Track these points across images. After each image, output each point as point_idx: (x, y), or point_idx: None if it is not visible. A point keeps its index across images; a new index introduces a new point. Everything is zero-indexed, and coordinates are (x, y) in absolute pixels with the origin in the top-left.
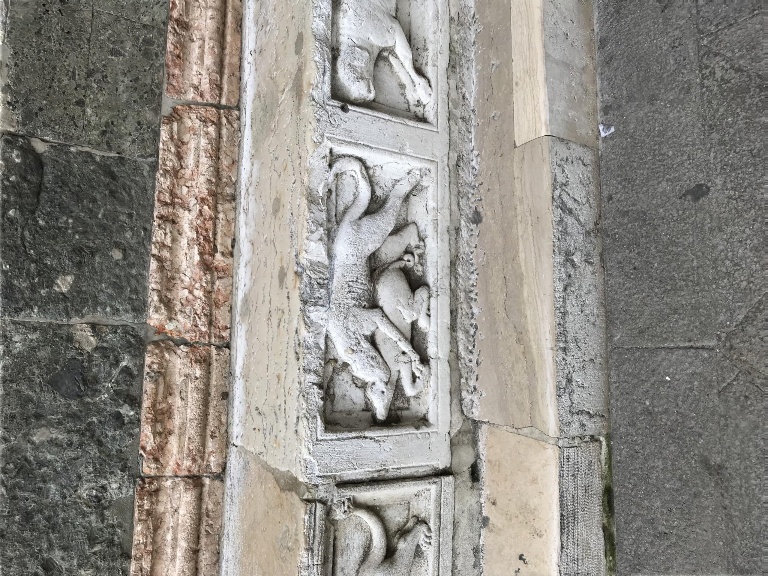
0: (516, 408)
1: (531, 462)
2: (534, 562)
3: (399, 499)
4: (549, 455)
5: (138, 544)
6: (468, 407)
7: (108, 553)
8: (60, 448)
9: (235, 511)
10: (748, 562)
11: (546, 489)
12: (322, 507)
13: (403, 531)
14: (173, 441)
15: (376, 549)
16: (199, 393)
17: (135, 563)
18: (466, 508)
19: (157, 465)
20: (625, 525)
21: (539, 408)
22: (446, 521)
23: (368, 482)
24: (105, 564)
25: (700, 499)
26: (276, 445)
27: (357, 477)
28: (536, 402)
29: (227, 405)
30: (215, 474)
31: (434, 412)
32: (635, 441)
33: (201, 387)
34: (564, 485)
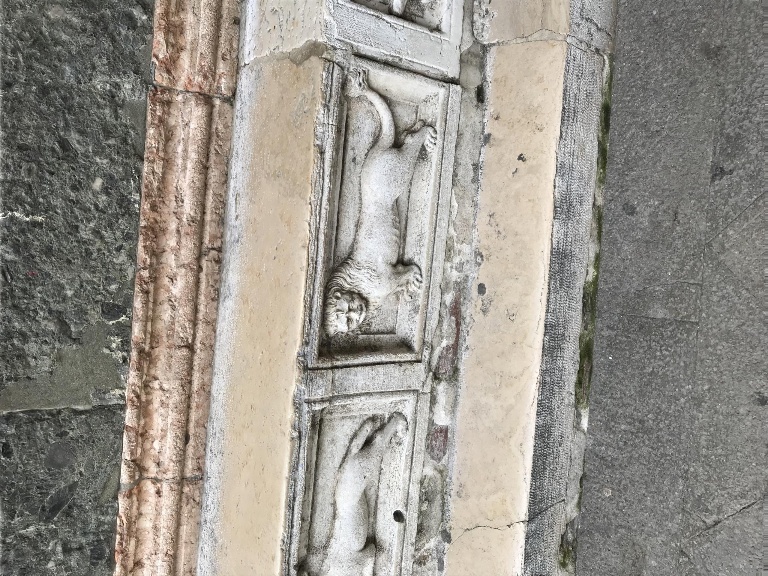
0: (528, 16)
1: (538, 63)
2: (532, 156)
3: (409, 99)
4: (557, 51)
5: (150, 147)
6: (479, 31)
7: (121, 150)
8: (75, 30)
9: (245, 124)
10: (734, 129)
11: (551, 84)
12: (339, 69)
13: (410, 131)
14: (185, 56)
15: (385, 136)
16: (212, 10)
17: (147, 165)
18: (470, 123)
19: (169, 76)
20: (618, 137)
21: (551, 8)
22: (451, 128)
23: (383, 63)
24: (119, 159)
25: (695, 85)
26: (294, 26)
27: (373, 54)
28: (549, 3)
29: (239, 31)
30: (225, 96)
31: (447, 22)
32: (638, 54)
33: (214, 5)
34: (568, 80)
